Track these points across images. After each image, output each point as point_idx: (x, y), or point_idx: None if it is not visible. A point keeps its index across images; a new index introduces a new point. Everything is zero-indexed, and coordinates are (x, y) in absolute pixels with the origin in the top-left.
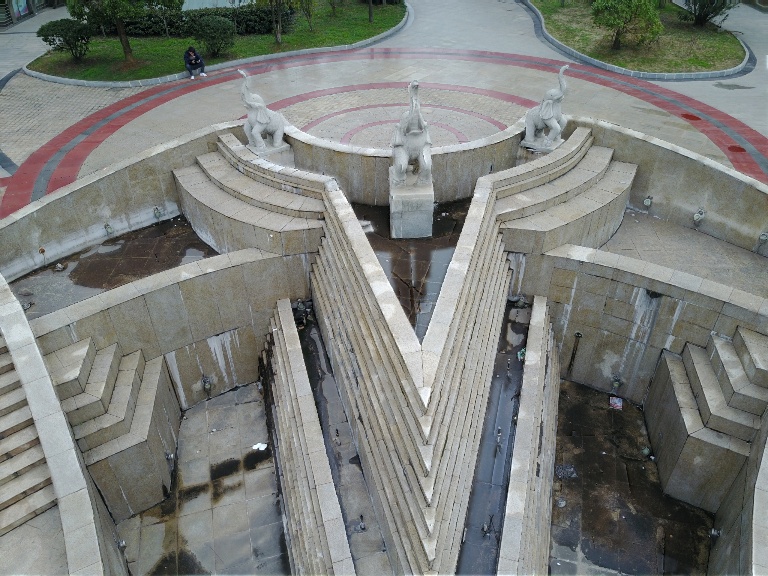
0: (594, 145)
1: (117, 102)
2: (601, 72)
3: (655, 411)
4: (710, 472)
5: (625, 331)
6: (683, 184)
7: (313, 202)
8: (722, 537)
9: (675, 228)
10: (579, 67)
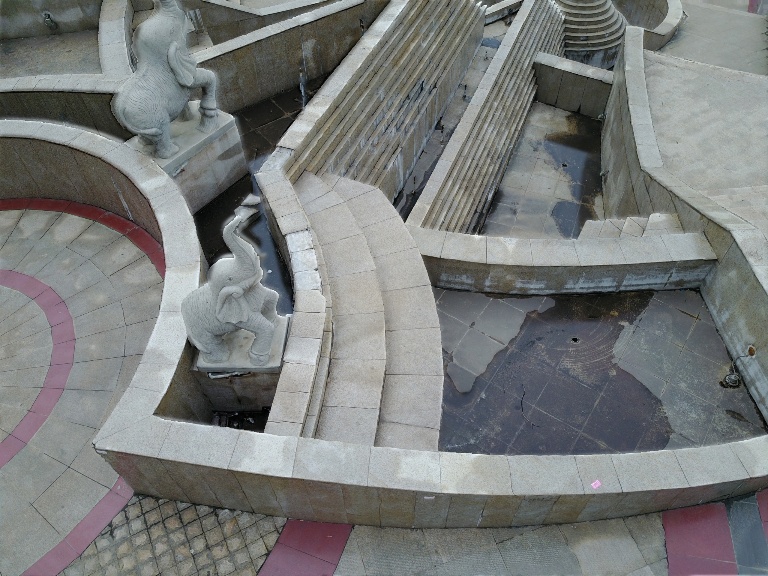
0: None
1: None
2: None
3: None
4: None
5: None
6: None
7: (303, 193)
8: None
9: None
10: None
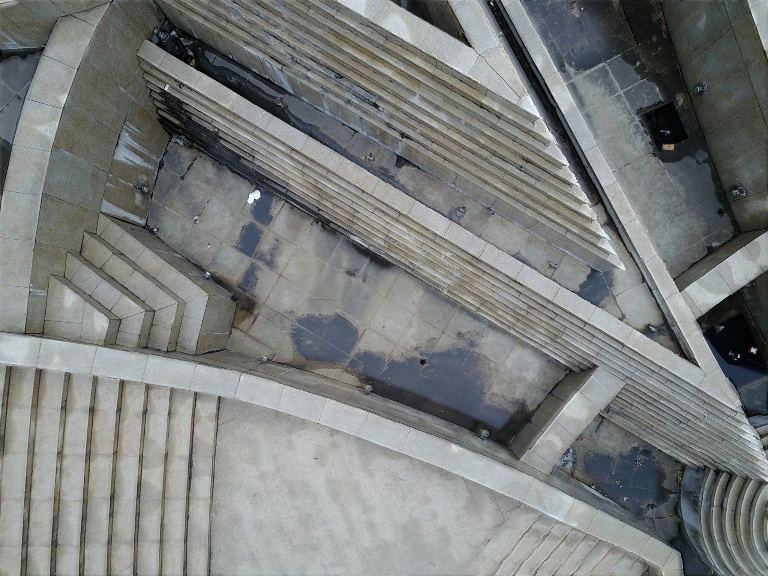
0: None
1: None
2: None
3: None
4: None
5: None
6: None
7: None
8: None
9: None
10: None
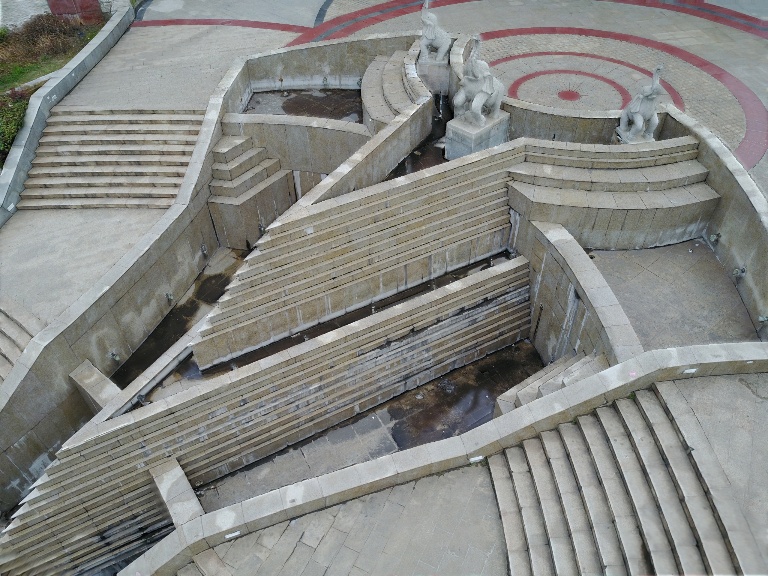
0: (696, 160)
1: None
2: None
3: None
4: None
5: (562, 319)
6: (743, 233)
7: None
8: None
9: (717, 274)
10: None
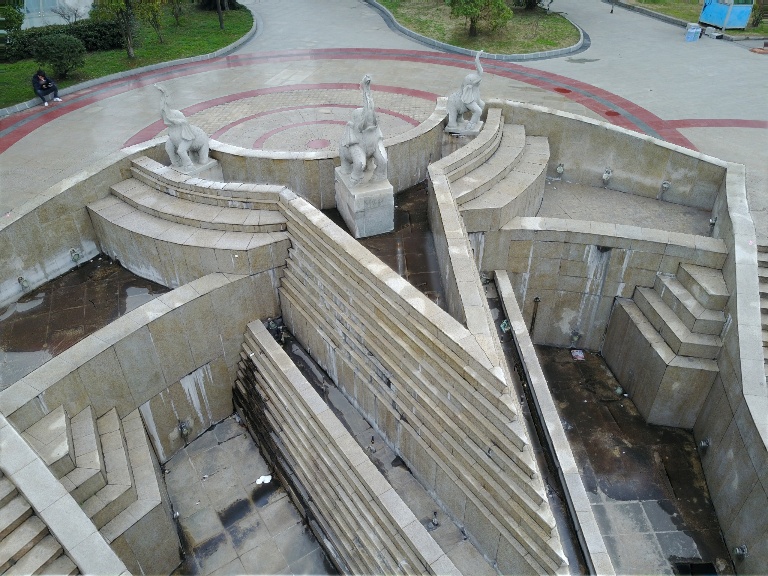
0: (505, 124)
1: None
2: (467, 58)
3: (618, 353)
4: (687, 393)
5: (580, 287)
6: (590, 149)
7: (270, 214)
8: (714, 445)
9: (588, 189)
10: (446, 55)
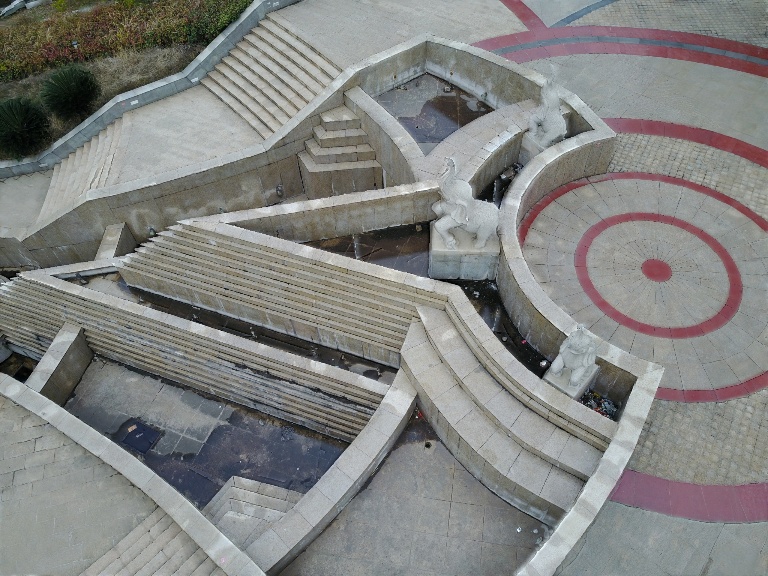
0: (602, 454)
1: (732, 40)
2: None
3: None
4: None
5: None
6: None
7: None
8: None
9: (501, 575)
10: None
